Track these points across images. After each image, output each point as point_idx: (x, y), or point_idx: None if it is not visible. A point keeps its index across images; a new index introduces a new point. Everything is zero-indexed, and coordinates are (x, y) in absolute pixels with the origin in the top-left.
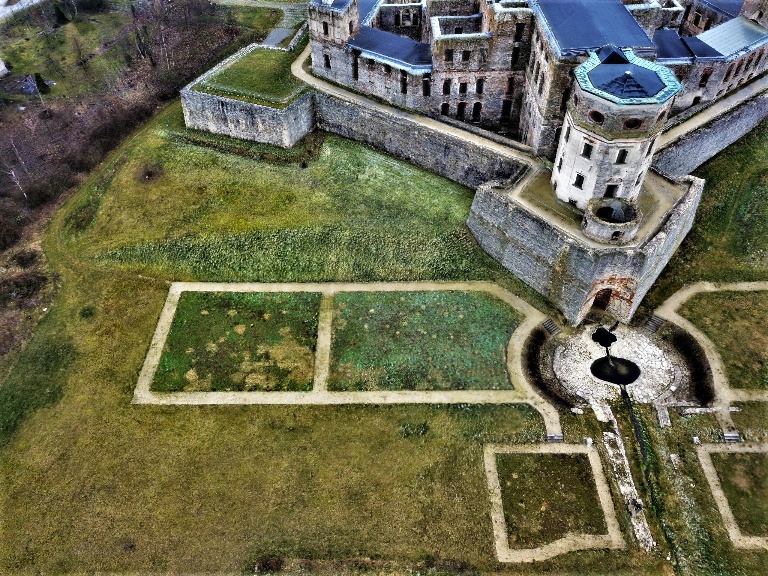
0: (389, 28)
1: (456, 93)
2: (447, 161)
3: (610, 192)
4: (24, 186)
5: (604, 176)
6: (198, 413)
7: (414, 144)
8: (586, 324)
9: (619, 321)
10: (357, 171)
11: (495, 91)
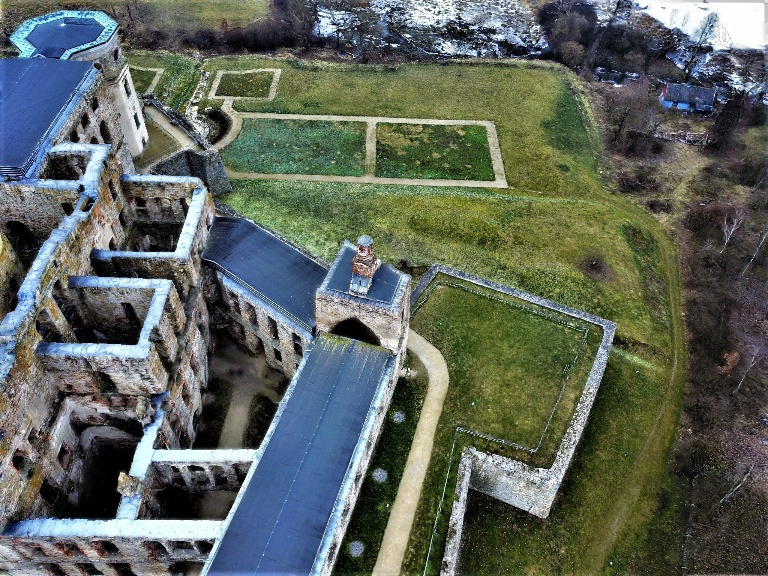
0: None
1: None
2: None
3: None
4: None
5: None
6: (448, 116)
7: None
8: None
9: None
10: None
11: None
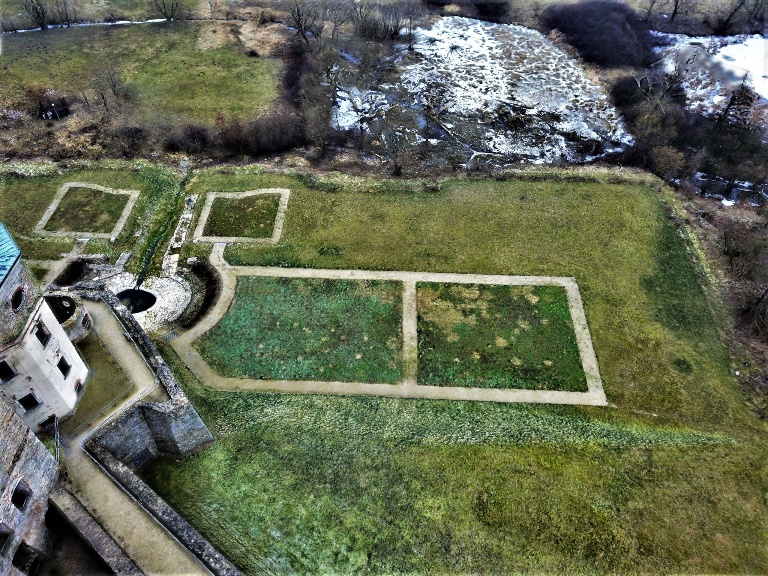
0: None
1: None
2: None
3: None
4: None
5: None
6: (512, 269)
7: None
8: None
9: None
10: (369, 575)
11: None
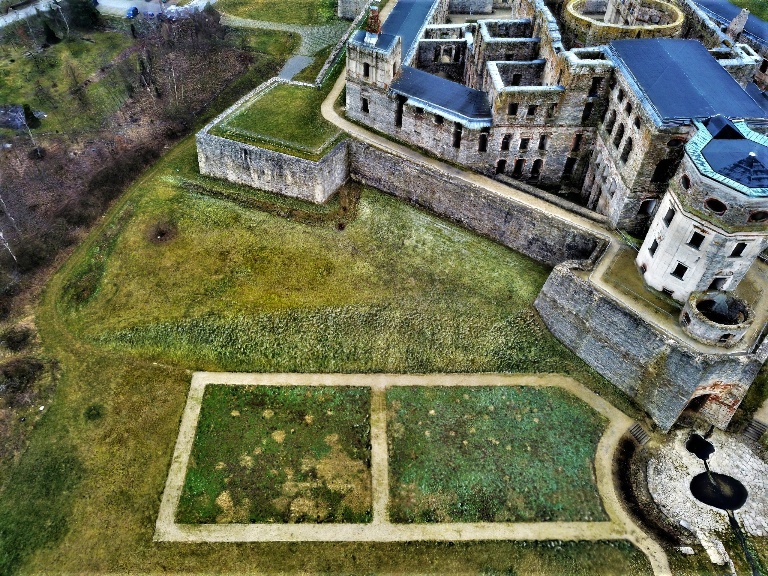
0: (428, 65)
1: (516, 149)
2: (507, 228)
3: (715, 284)
4: (13, 245)
5: (713, 269)
6: (236, 554)
7: (468, 206)
8: (677, 429)
9: (714, 426)
10: (402, 235)
11: (559, 148)
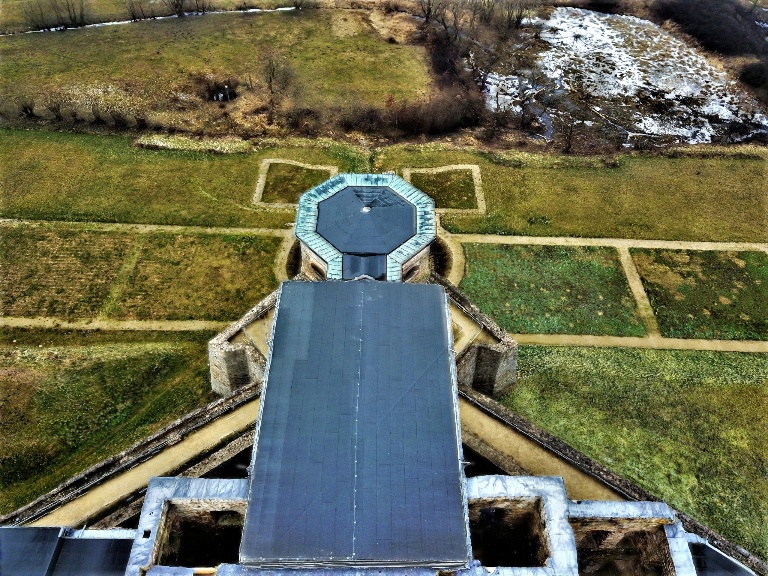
0: None
1: None
2: None
3: None
4: None
5: None
6: (712, 236)
7: None
8: None
9: None
10: (705, 493)
11: None
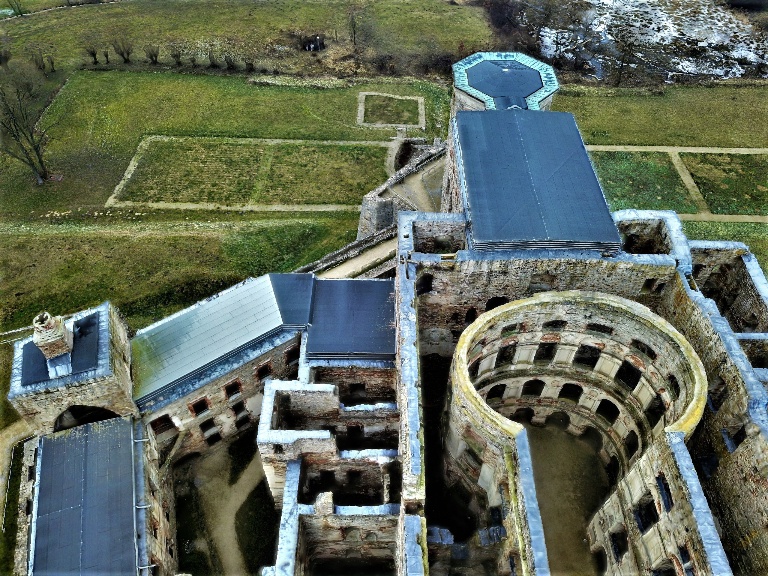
0: None
1: None
2: None
3: None
4: None
5: None
6: (748, 144)
7: None
8: None
9: None
10: None
11: None
